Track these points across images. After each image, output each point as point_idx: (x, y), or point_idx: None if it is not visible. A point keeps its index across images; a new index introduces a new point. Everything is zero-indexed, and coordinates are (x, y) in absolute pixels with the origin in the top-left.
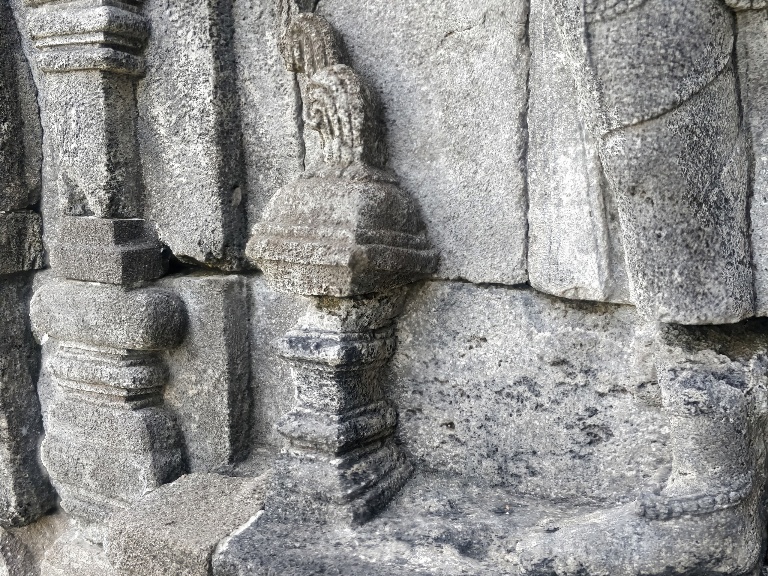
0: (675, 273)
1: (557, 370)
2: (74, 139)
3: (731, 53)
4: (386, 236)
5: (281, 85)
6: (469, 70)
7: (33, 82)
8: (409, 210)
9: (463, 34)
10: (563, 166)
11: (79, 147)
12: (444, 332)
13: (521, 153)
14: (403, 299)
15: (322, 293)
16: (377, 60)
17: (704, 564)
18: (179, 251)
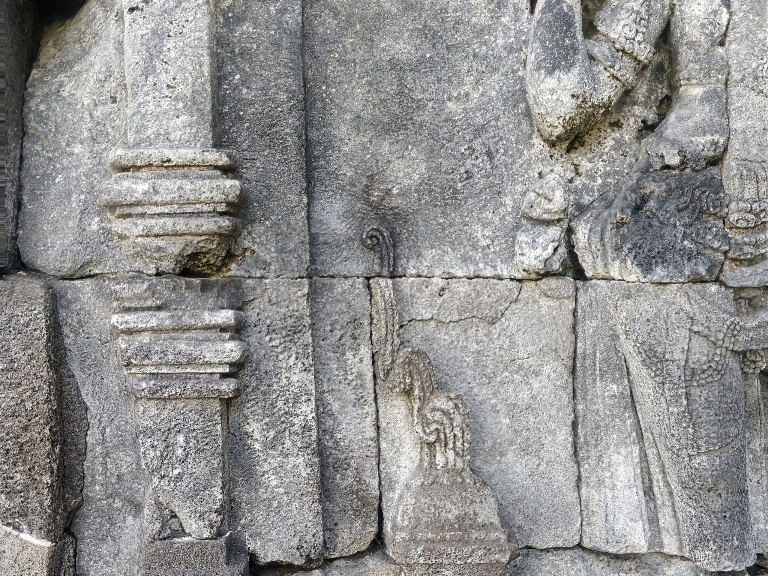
0: (735, 540)
1: None
2: (179, 464)
3: None
4: None
5: (361, 397)
6: (529, 389)
7: (82, 398)
8: None
9: (524, 362)
10: (617, 462)
11: (185, 472)
12: None
13: (573, 450)
14: None
15: None
16: (451, 378)
17: None
18: (274, 558)
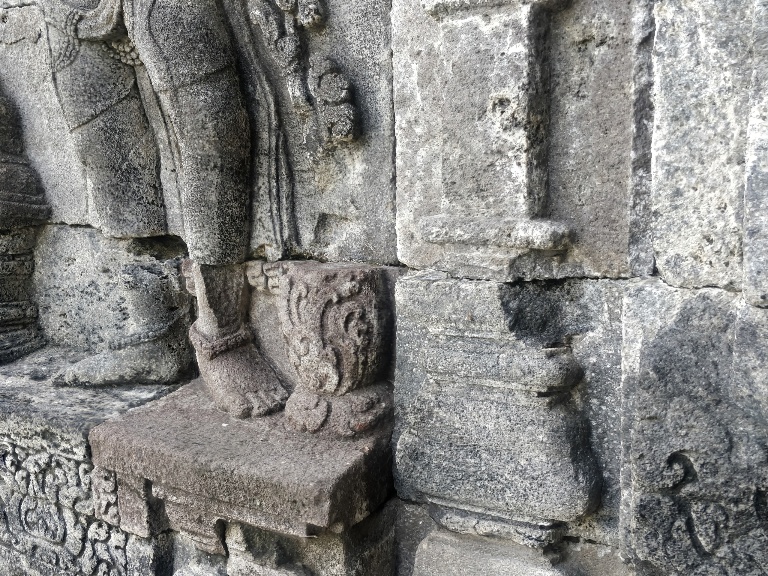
0: (107, 209)
1: (106, 275)
2: None
3: (133, 88)
4: (3, 195)
5: None
6: None
7: None
8: (28, 180)
9: None
10: None
11: None
12: (56, 256)
13: None
14: (33, 236)
15: None
16: (16, 89)
17: (141, 374)
18: None
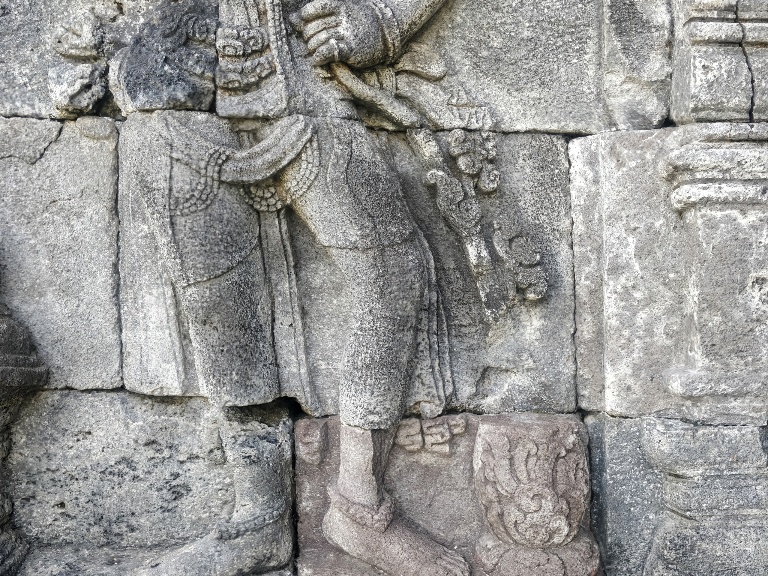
0: (233, 374)
1: (149, 449)
2: None
3: (258, 236)
4: (10, 359)
5: None
6: (70, 230)
7: None
8: (24, 337)
9: (65, 203)
10: (149, 303)
11: None
12: (54, 431)
13: (115, 292)
14: (18, 408)
15: None
16: None
17: (260, 563)
18: None
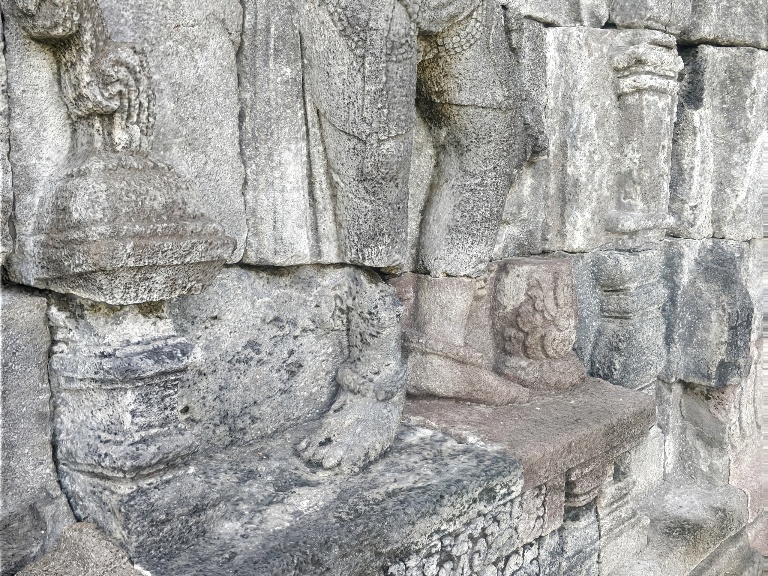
0: None
1: (271, 327)
2: None
3: None
4: None
5: None
6: (195, 66)
7: None
8: None
9: (189, 30)
10: (288, 159)
11: None
12: (184, 319)
13: None
14: None
15: (182, 294)
16: None
17: None
18: None
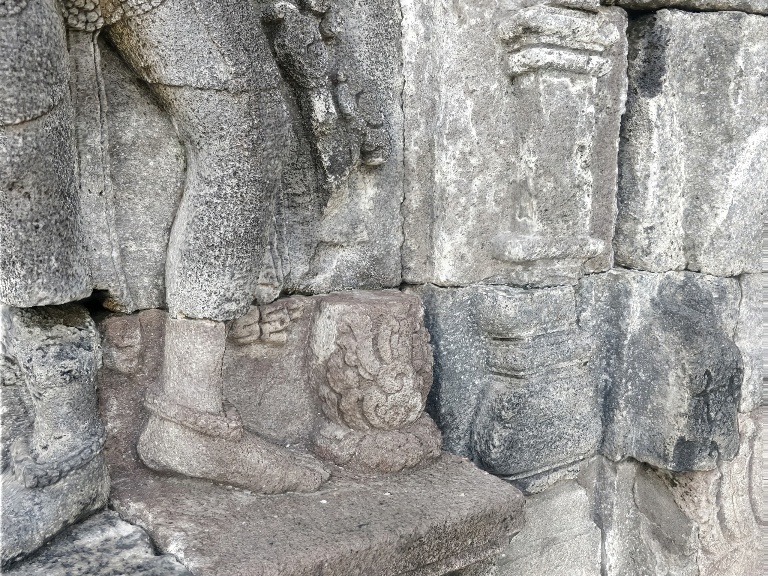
0: (53, 260)
1: None
2: None
3: None
4: None
5: None
6: None
7: None
8: None
9: None
10: None
11: None
12: None
13: None
14: None
15: None
16: None
17: (86, 508)
18: None
